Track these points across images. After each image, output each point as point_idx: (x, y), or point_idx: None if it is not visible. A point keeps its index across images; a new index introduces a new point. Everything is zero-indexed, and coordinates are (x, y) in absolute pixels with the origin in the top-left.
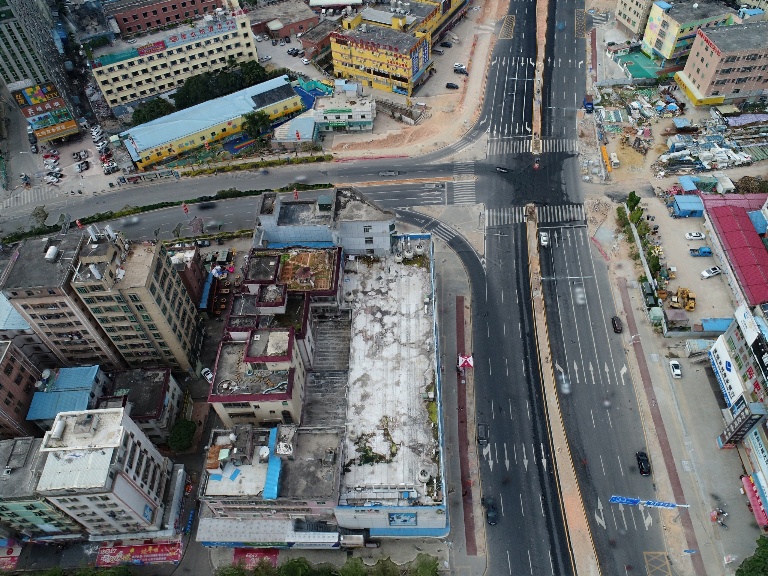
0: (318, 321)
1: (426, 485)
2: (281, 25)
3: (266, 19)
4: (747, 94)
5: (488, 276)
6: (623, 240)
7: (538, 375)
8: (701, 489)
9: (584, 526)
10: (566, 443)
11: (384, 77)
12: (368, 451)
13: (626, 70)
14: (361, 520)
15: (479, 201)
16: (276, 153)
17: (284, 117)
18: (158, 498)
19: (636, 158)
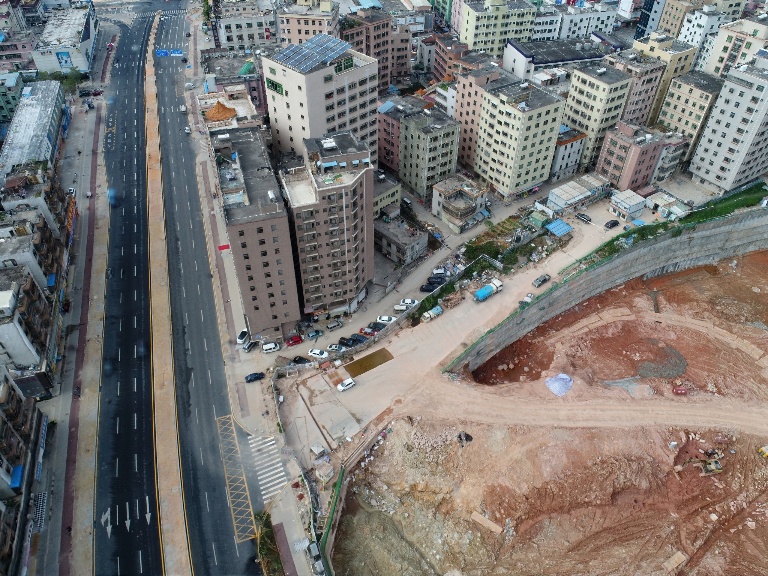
0: (31, 25)
1: None
2: None
3: None
4: None
5: (131, 29)
6: (202, 16)
7: (146, 48)
8: None
9: None
10: (153, 60)
11: None
12: (49, 44)
13: None
14: (47, 64)
15: None
16: None
17: None
18: None
19: None
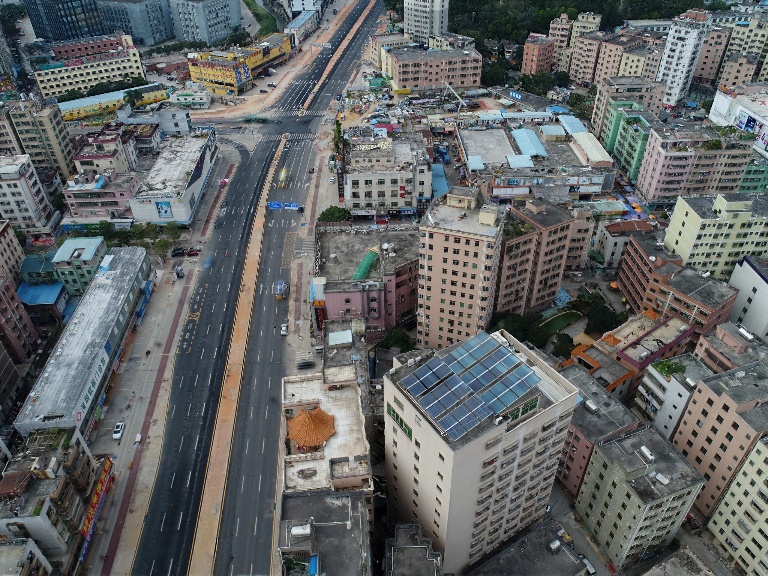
0: (143, 157)
1: (177, 195)
2: (165, 65)
3: (156, 62)
4: (423, 88)
5: (252, 158)
6: (332, 144)
7: (262, 187)
8: None
9: (261, 226)
10: (265, 205)
11: (221, 85)
12: (153, 188)
13: (368, 83)
14: (145, 213)
15: (259, 133)
16: None
17: None
18: (43, 213)
19: (356, 117)
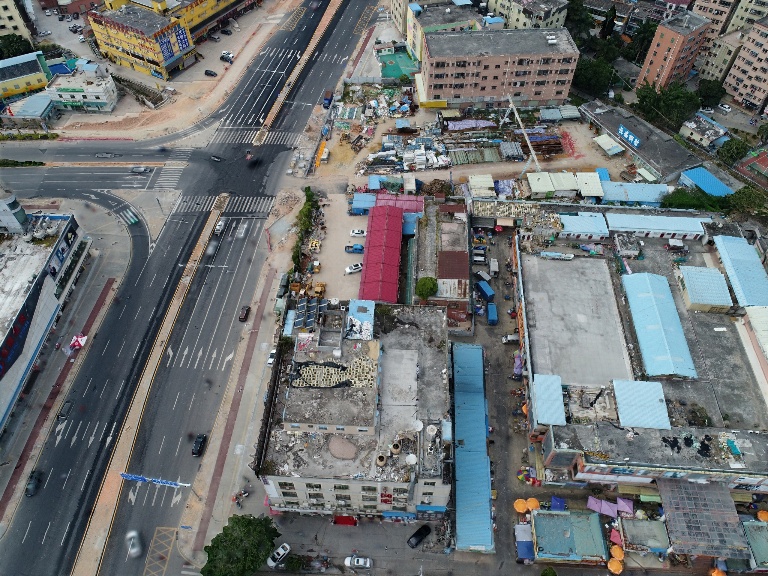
0: None
1: None
2: (69, 1)
3: None
4: (469, 100)
5: (149, 261)
6: (294, 233)
7: (146, 358)
8: (239, 471)
9: (113, 501)
10: (138, 423)
11: (141, 60)
12: None
13: (380, 69)
14: None
15: (178, 188)
16: (4, 128)
17: (32, 93)
18: None
19: (349, 155)
